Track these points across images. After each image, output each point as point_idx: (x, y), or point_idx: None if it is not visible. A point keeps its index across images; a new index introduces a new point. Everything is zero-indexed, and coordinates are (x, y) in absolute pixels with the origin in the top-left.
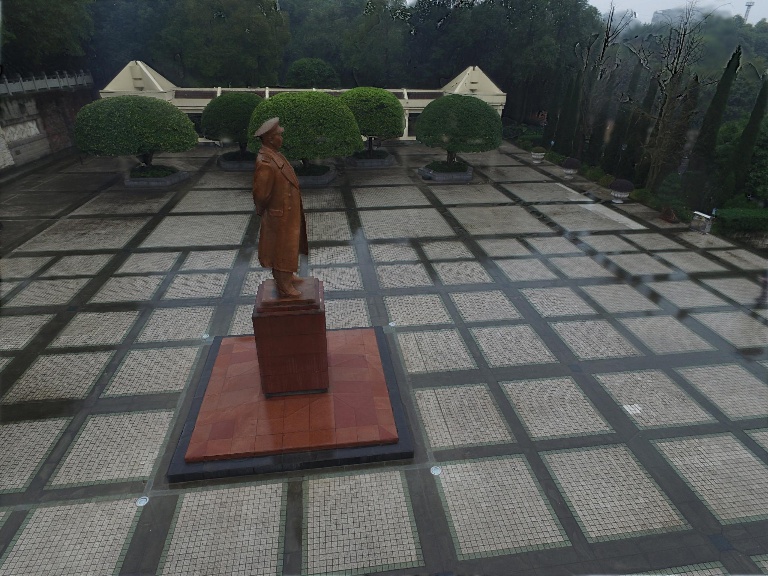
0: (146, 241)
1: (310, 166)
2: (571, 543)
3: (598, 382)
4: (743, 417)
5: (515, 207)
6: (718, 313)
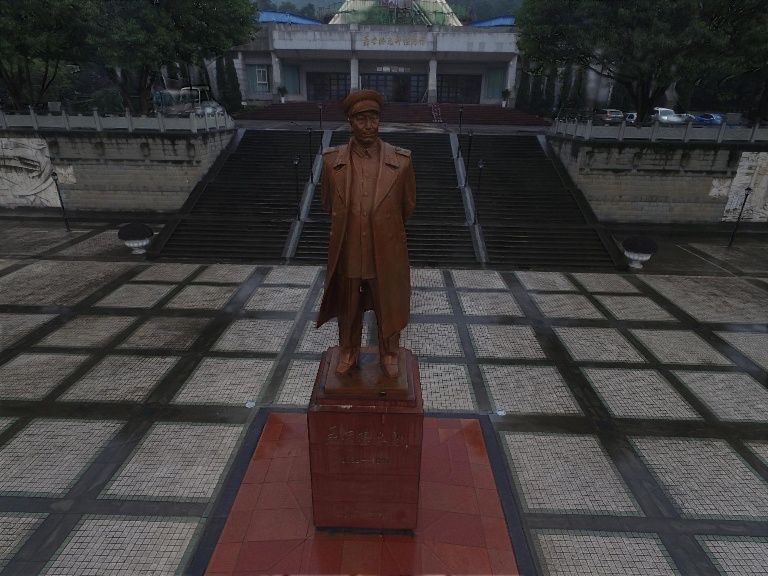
0: (740, 333)
1: None
2: None
3: None
4: None
5: None
6: None
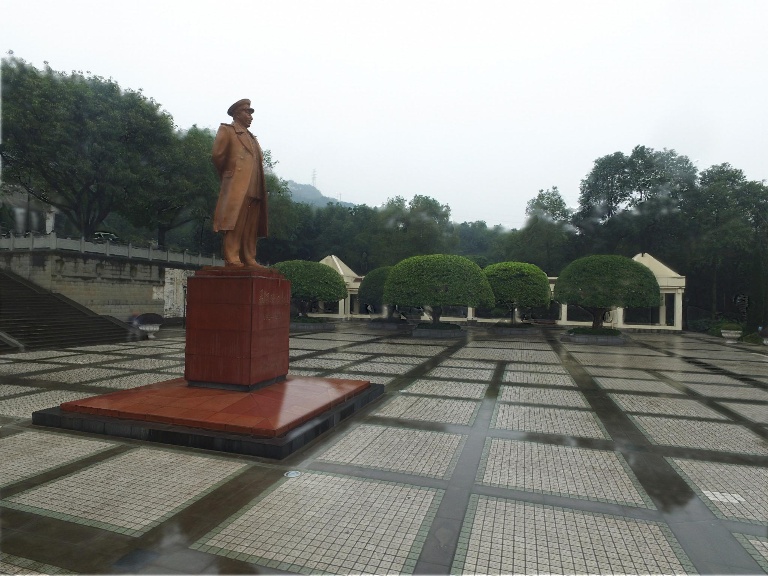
0: None
1: (440, 323)
2: None
3: (669, 463)
4: None
5: (667, 358)
6: None
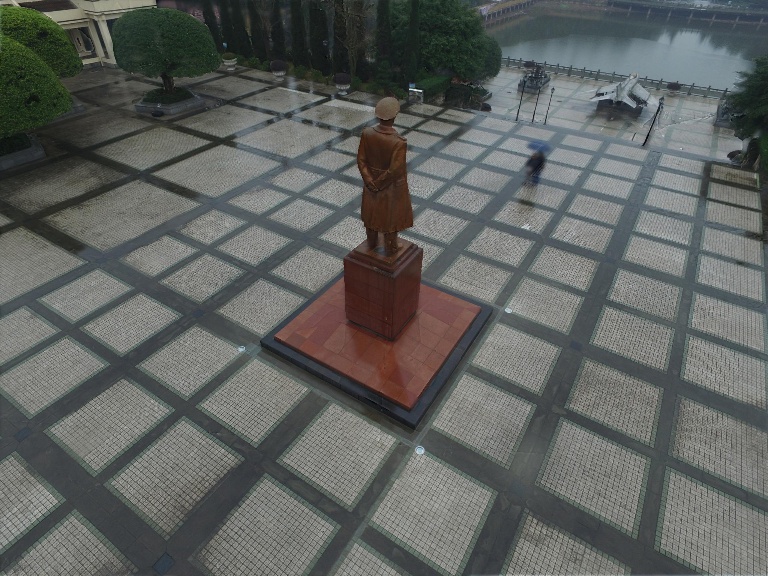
0: None
1: None
2: (584, 297)
3: (499, 222)
4: (558, 206)
5: (284, 121)
6: (489, 156)
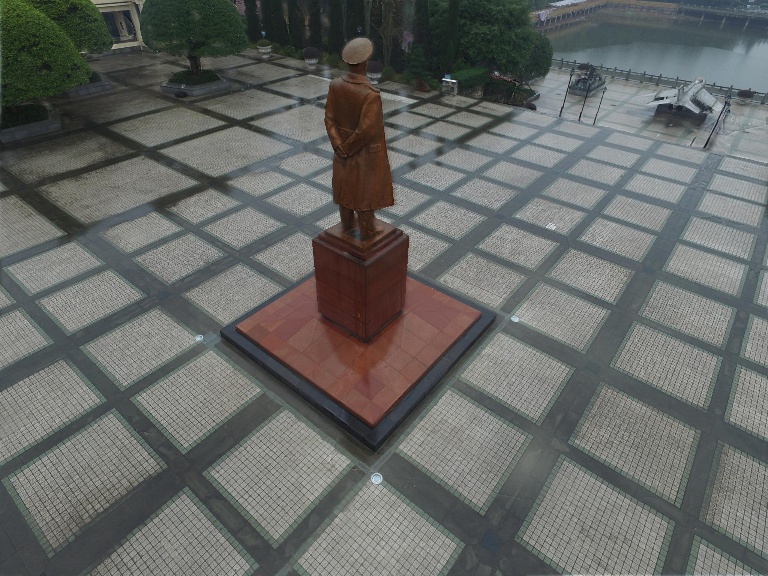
0: None
1: (18, 109)
2: (610, 310)
3: (520, 219)
4: (593, 206)
5: (306, 106)
6: (520, 150)
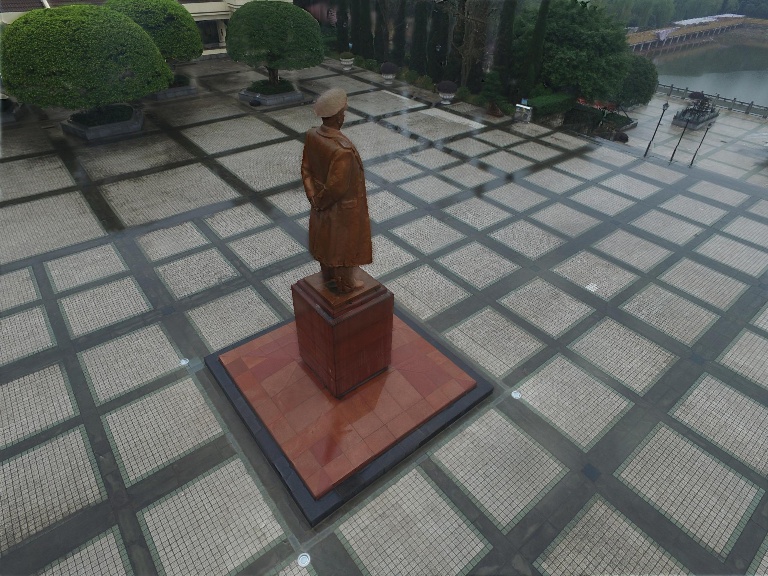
0: None
1: (107, 109)
2: (634, 402)
3: (558, 274)
4: (650, 268)
5: (369, 124)
6: (583, 192)
